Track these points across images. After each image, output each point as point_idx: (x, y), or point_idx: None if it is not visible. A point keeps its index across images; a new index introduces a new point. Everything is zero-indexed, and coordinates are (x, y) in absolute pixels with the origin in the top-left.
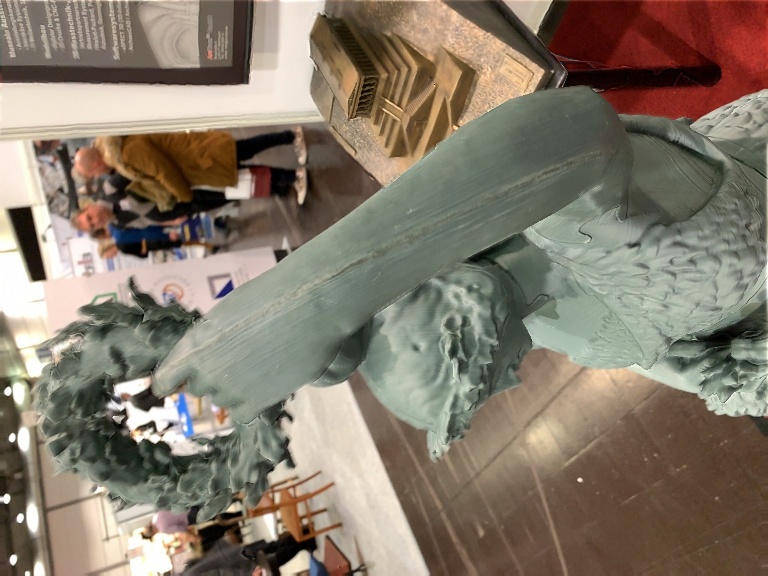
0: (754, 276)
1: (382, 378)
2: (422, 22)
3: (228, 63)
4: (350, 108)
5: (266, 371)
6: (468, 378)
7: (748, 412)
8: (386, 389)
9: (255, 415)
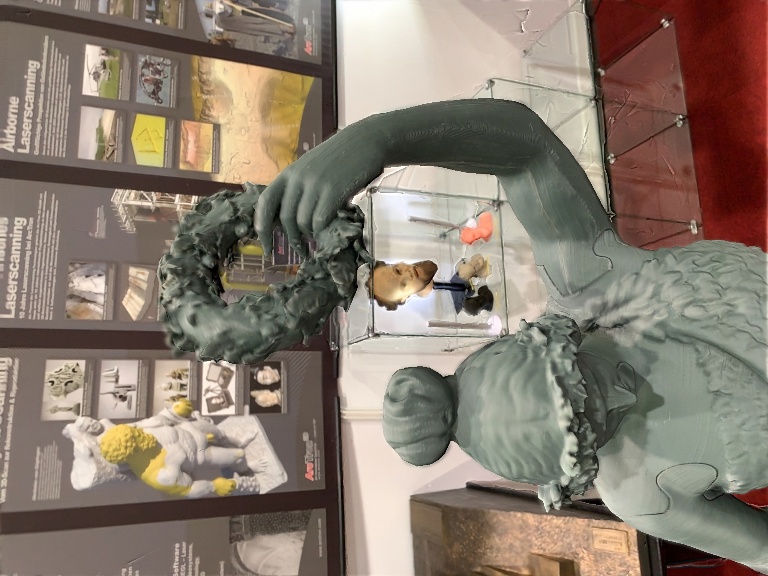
0: None
1: (478, 396)
2: (505, 540)
3: None
4: None
5: (336, 156)
6: (555, 342)
7: None
8: (485, 403)
9: (333, 206)
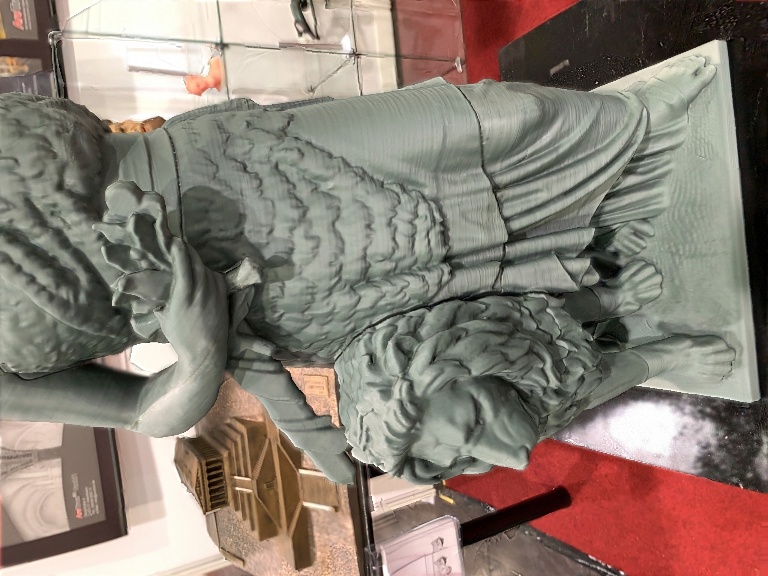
0: (46, 127)
1: None
2: (244, 393)
3: (101, 517)
4: (201, 499)
5: None
6: None
7: (394, 428)
8: None
9: None
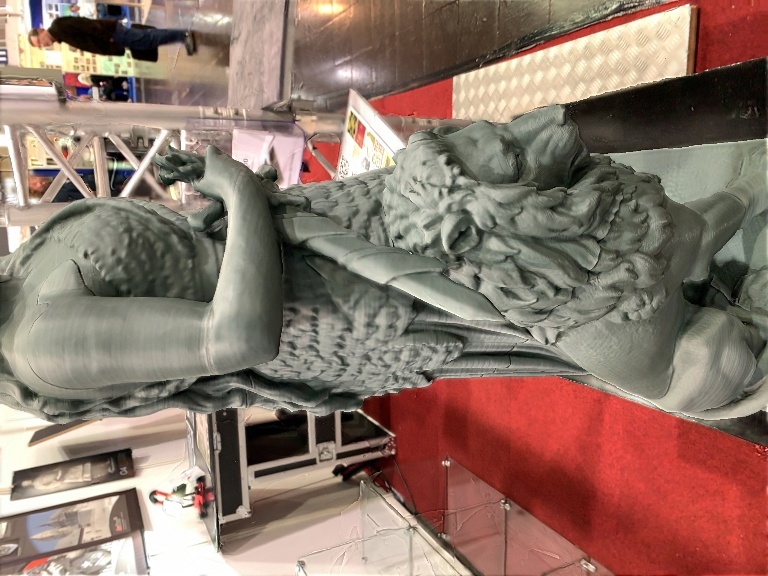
0: None
1: None
2: None
3: None
4: None
5: None
6: None
7: None
8: None
9: None
